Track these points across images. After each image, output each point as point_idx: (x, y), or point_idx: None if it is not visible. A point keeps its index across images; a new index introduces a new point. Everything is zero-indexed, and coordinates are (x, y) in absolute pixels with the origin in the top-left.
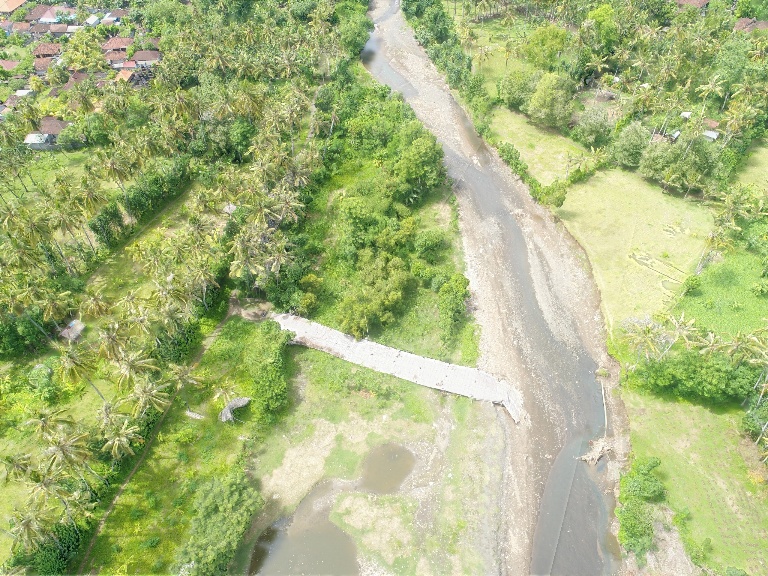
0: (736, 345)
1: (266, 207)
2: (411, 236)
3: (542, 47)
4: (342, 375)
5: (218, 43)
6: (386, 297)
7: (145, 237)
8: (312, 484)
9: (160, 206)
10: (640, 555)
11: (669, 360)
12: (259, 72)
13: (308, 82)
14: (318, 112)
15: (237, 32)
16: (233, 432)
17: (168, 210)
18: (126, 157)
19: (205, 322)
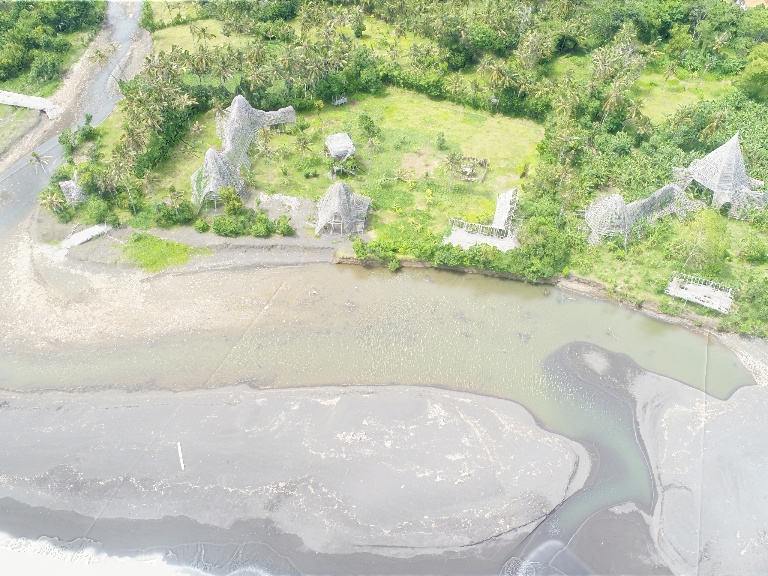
0: None
1: None
2: None
3: None
4: None
5: None
6: (0, 61)
7: None
8: None
9: None
10: (66, 157)
11: (130, 80)
12: None
13: None
14: None
15: None
16: None
17: None
18: None
19: None
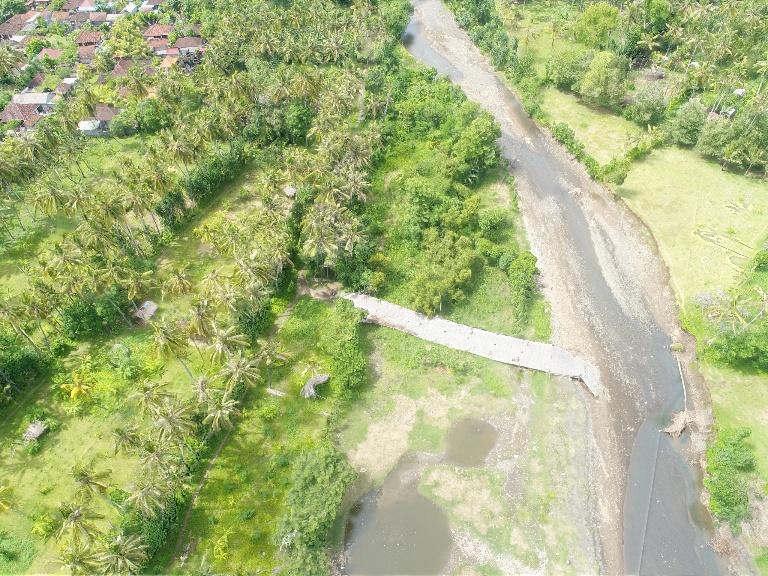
0: None
1: (335, 187)
2: (474, 215)
3: (594, 26)
4: (420, 351)
5: (264, 28)
6: (457, 275)
7: (206, 220)
8: (398, 458)
9: (218, 190)
10: (735, 523)
11: (751, 332)
12: (306, 56)
13: (354, 66)
14: (369, 95)
15: (283, 16)
16: (315, 408)
17: (226, 193)
18: (190, 140)
19: (276, 302)
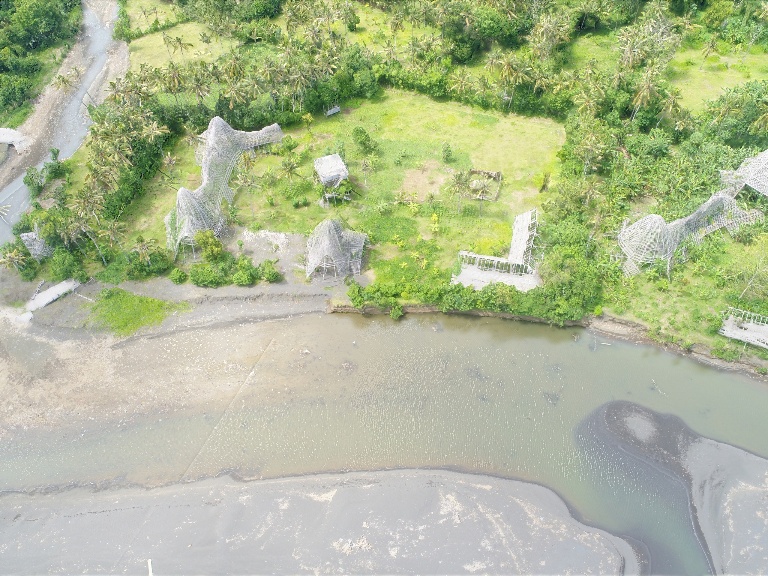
0: None
1: None
2: None
3: None
4: None
5: None
6: None
7: None
8: None
9: None
10: (33, 199)
11: (100, 105)
12: None
13: None
14: None
15: None
16: None
17: None
18: None
19: None
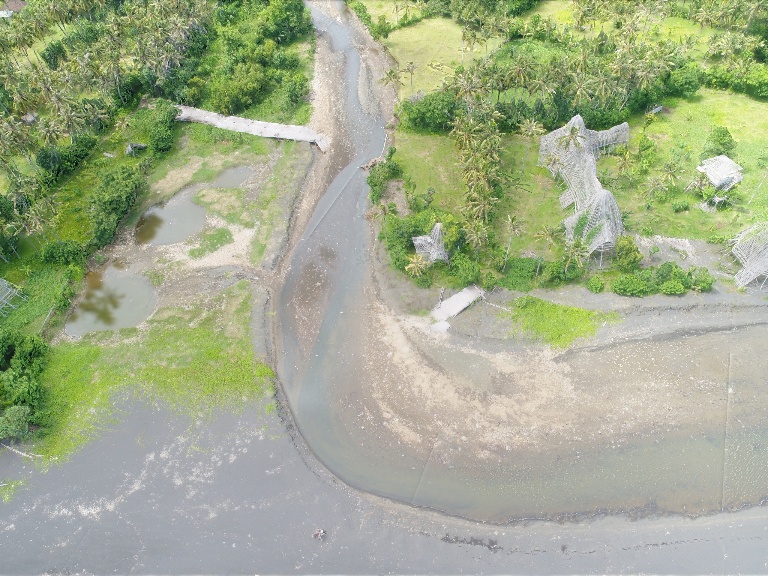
0: (454, 84)
1: None
2: (273, 57)
3: None
4: (208, 126)
5: None
6: (245, 86)
7: None
8: (183, 185)
9: None
10: (377, 200)
11: (418, 102)
12: None
13: None
14: None
15: None
16: (134, 161)
17: None
18: (65, 5)
19: (121, 110)
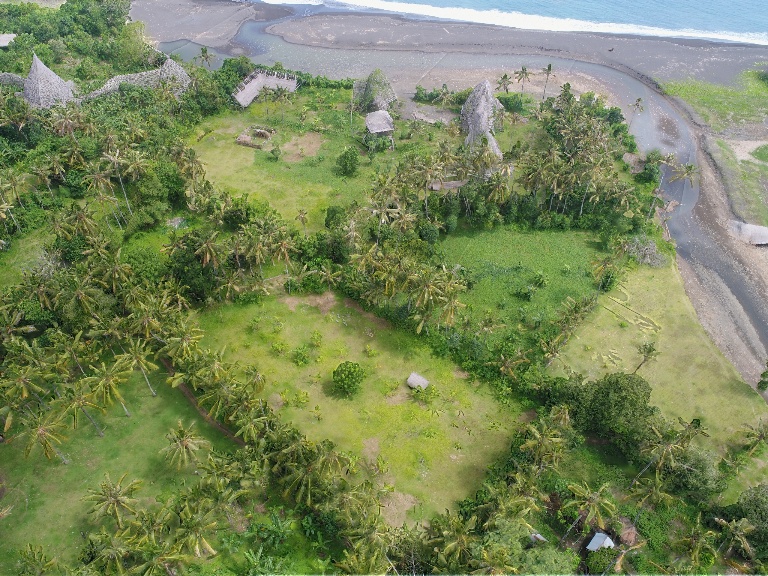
0: None
1: None
2: None
3: None
4: None
5: None
6: None
7: None
8: None
9: None
10: None
11: None
12: None
13: None
14: None
15: None
16: None
17: None
18: None
19: None
